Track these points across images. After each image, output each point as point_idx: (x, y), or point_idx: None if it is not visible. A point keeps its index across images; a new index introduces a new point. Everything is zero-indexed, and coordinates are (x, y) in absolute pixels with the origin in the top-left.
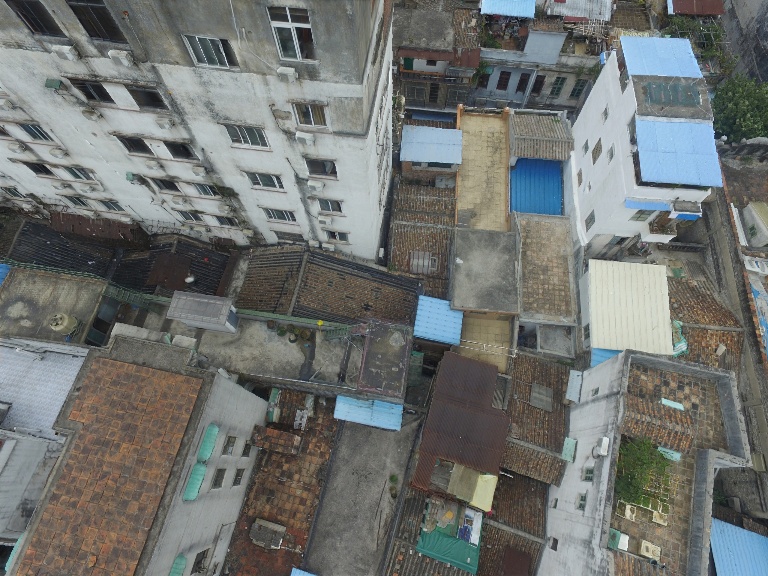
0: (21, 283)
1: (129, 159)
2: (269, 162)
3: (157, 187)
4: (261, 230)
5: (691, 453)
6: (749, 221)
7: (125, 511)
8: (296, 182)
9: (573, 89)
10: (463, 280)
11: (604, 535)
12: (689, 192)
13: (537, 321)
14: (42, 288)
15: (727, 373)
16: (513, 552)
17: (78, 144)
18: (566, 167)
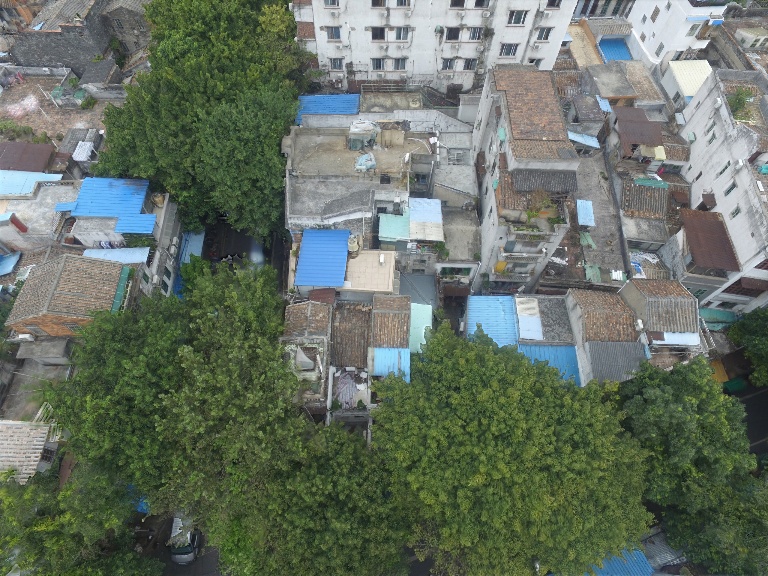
0: (371, 99)
1: (446, 13)
2: (528, 1)
3: (445, 38)
4: None
5: (755, 104)
6: (739, 37)
7: (545, 111)
8: (535, 16)
9: (614, 8)
10: (601, 86)
11: (734, 124)
12: (717, 8)
13: (645, 103)
14: (385, 100)
15: (760, 71)
16: (676, 192)
17: (423, 5)
18: (629, 39)
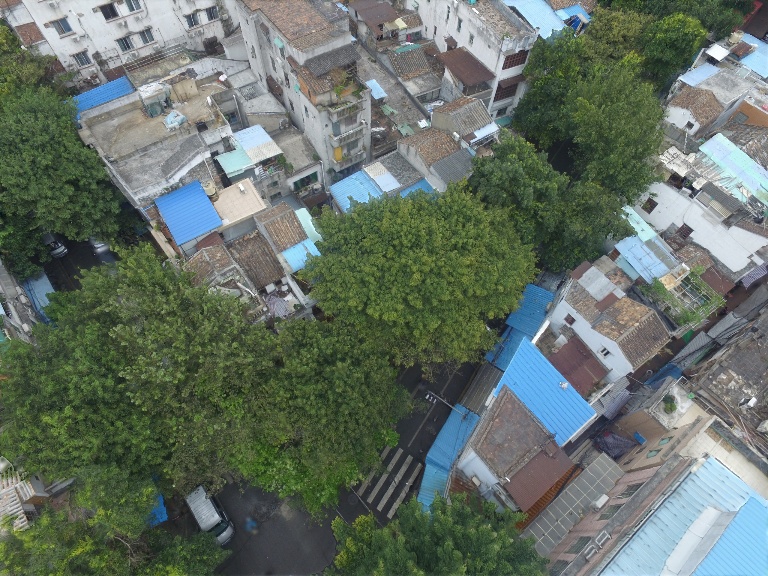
0: (140, 75)
1: None
2: None
3: None
4: (230, 12)
5: None
6: None
7: None
8: None
9: None
10: None
11: None
12: None
13: None
14: (154, 71)
15: None
16: (427, 50)
17: None
18: None
